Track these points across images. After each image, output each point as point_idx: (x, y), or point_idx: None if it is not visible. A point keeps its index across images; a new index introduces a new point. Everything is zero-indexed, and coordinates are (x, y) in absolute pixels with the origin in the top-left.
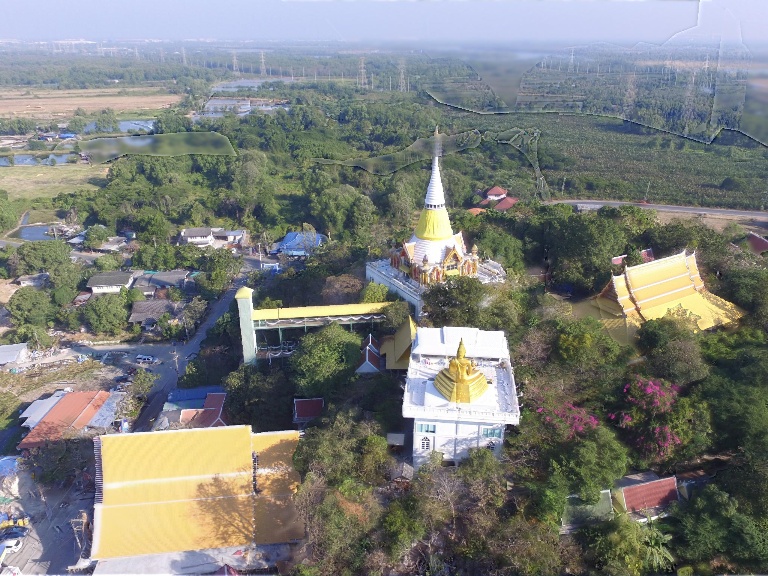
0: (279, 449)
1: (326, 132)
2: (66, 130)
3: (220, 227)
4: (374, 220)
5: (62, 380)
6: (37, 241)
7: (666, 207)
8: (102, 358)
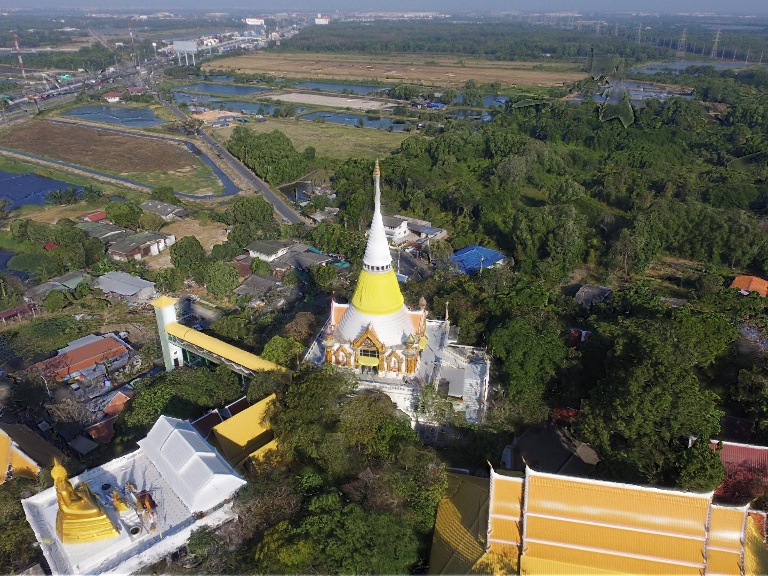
0: (26, 474)
1: (677, 134)
2: (439, 100)
3: (428, 221)
4: (590, 255)
5: (140, 324)
6: (252, 198)
7: None
8: (183, 316)
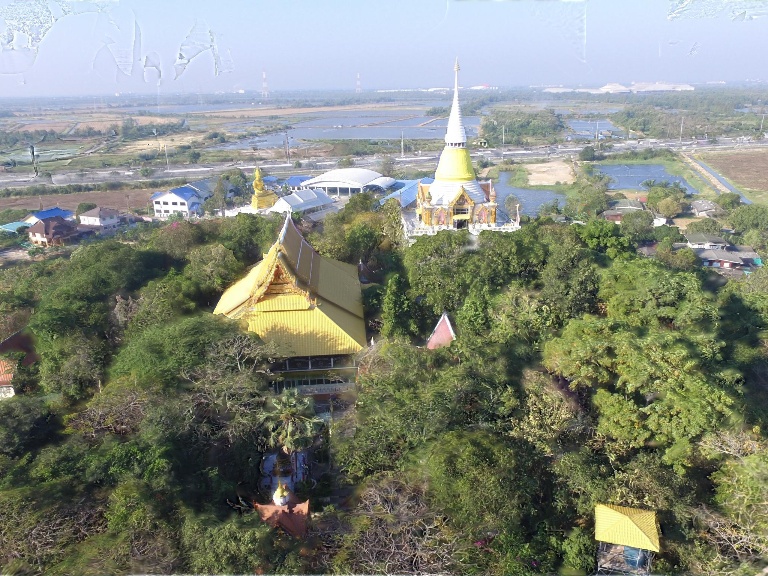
0: None
1: None
2: None
3: None
4: None
5: None
6: (761, 205)
7: None
8: None
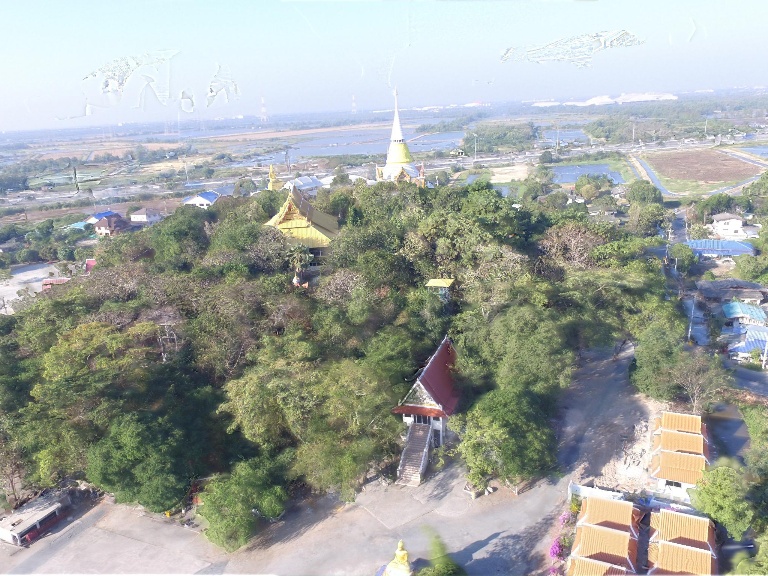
0: None
1: None
2: None
3: None
4: None
5: None
6: None
7: None
8: None
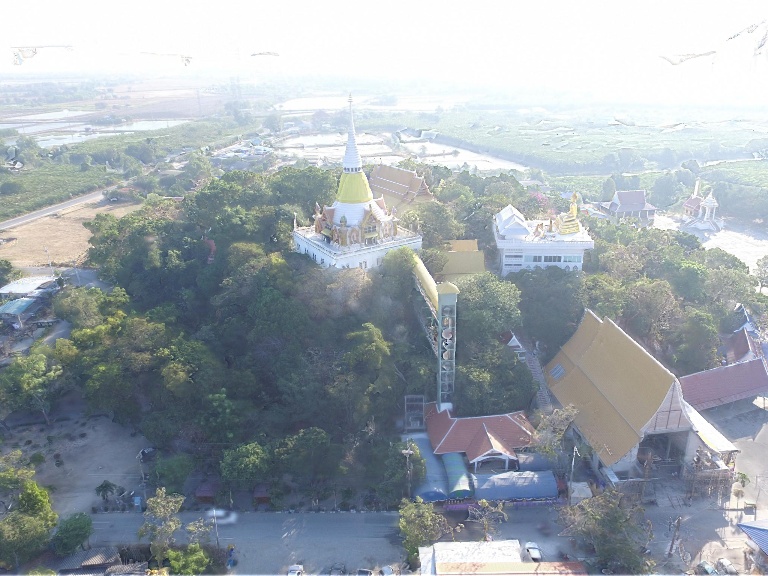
0: None
1: None
2: None
3: None
4: None
5: None
6: None
7: (11, 222)
8: None
